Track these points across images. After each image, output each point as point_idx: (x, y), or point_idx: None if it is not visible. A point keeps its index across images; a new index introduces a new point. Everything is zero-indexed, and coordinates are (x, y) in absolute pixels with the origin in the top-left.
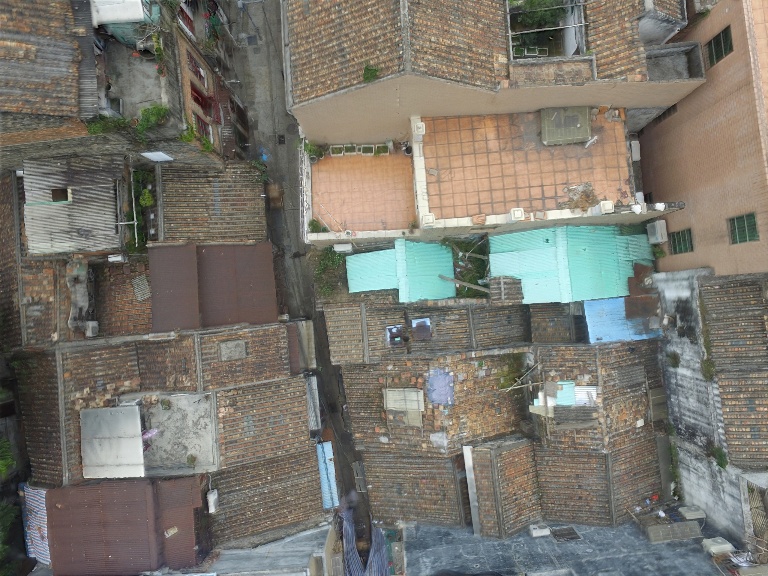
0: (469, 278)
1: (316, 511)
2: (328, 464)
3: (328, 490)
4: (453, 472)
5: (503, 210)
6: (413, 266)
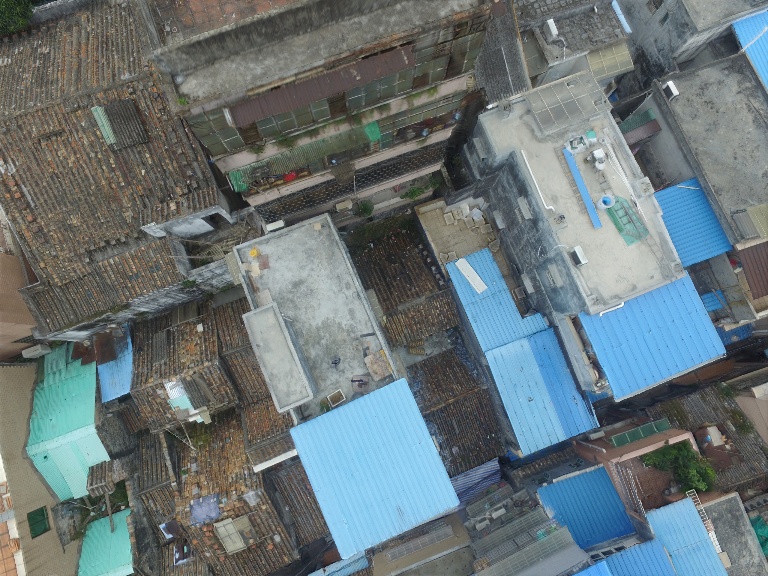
0: (115, 498)
1: (370, 575)
2: (329, 572)
3: (351, 567)
4: (288, 468)
5: (4, 523)
6: (100, 567)
